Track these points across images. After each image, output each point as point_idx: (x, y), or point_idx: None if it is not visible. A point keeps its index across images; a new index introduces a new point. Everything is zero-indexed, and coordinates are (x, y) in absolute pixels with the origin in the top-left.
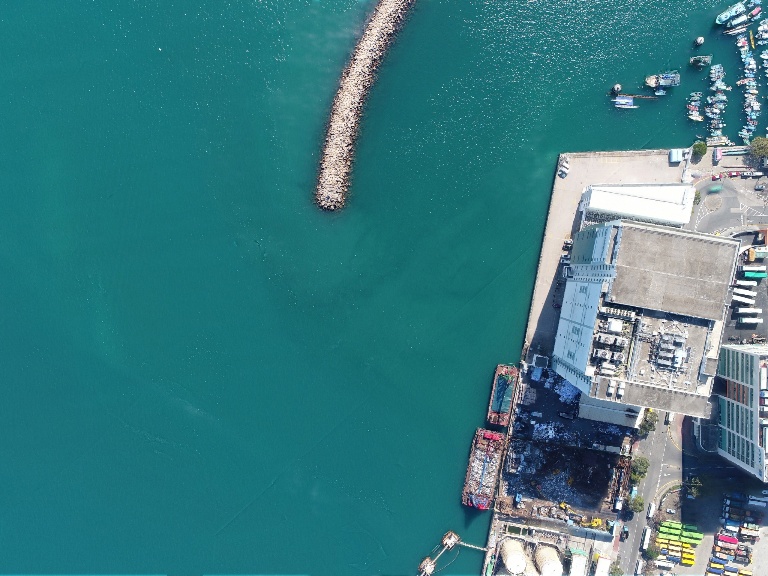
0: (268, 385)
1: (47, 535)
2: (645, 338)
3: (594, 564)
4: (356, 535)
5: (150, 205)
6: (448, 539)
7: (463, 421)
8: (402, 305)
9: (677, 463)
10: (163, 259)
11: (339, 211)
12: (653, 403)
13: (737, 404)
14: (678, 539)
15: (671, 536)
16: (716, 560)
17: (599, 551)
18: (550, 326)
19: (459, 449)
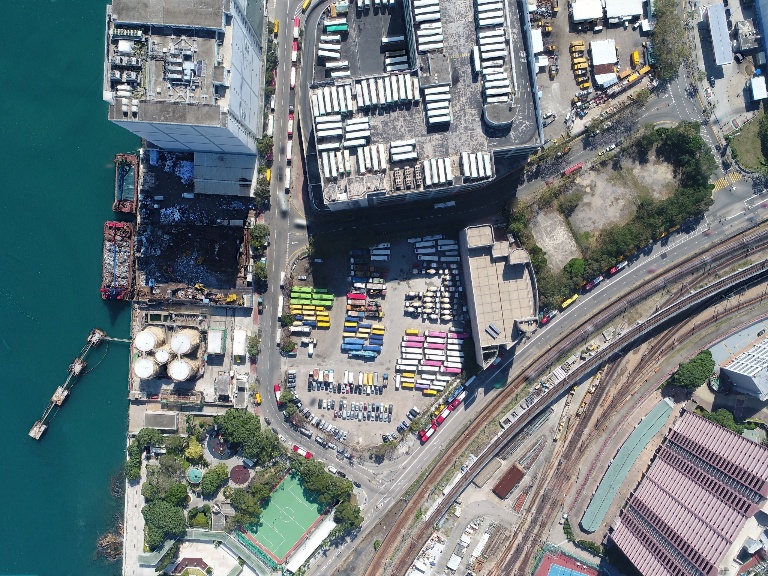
0: None
1: None
2: (157, 56)
3: None
4: None
5: None
6: (91, 335)
7: (93, 217)
8: (16, 107)
9: (302, 230)
10: None
11: None
12: (169, 118)
13: None
14: (310, 303)
15: (302, 300)
16: (349, 318)
17: (240, 327)
18: None
19: (93, 245)
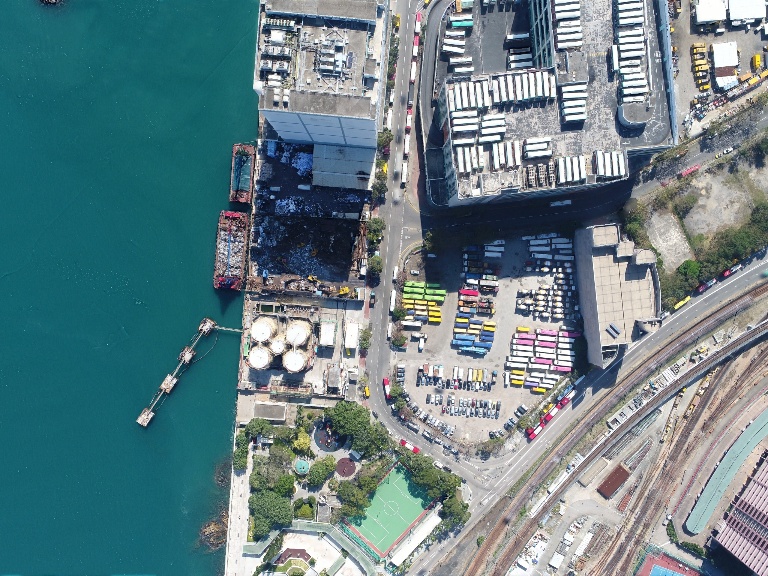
0: None
1: None
2: (308, 47)
3: None
4: None
5: None
6: (203, 324)
7: (207, 206)
8: (135, 94)
9: (416, 225)
10: None
11: (62, 4)
12: (319, 109)
13: (446, 142)
14: (423, 298)
15: (415, 295)
16: (461, 314)
17: (351, 320)
18: None
19: (206, 235)
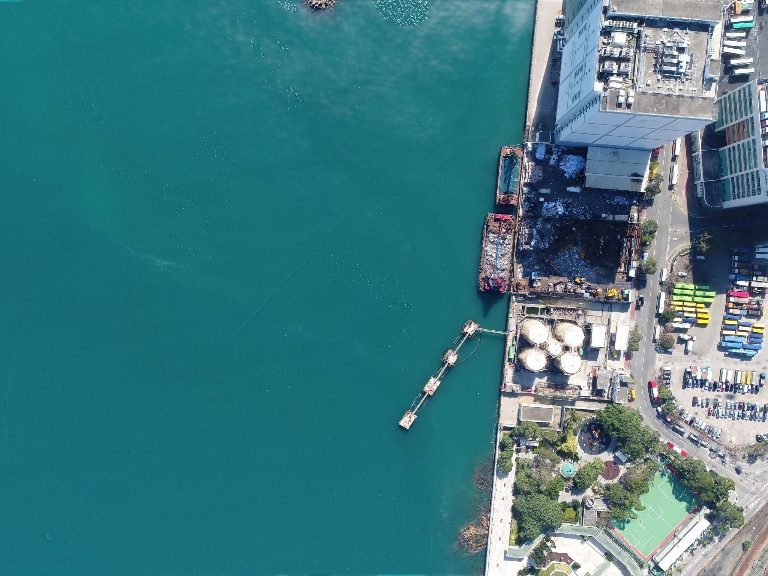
0: (276, 177)
1: (61, 367)
2: (649, 48)
3: (613, 335)
4: (376, 339)
5: (139, 4)
6: (468, 327)
7: (472, 209)
8: (402, 98)
9: (684, 226)
10: (158, 58)
11: (330, 10)
12: (662, 110)
13: (738, 143)
14: (692, 300)
15: (685, 297)
16: (730, 316)
17: (617, 322)
18: (550, 104)
19: (471, 237)
